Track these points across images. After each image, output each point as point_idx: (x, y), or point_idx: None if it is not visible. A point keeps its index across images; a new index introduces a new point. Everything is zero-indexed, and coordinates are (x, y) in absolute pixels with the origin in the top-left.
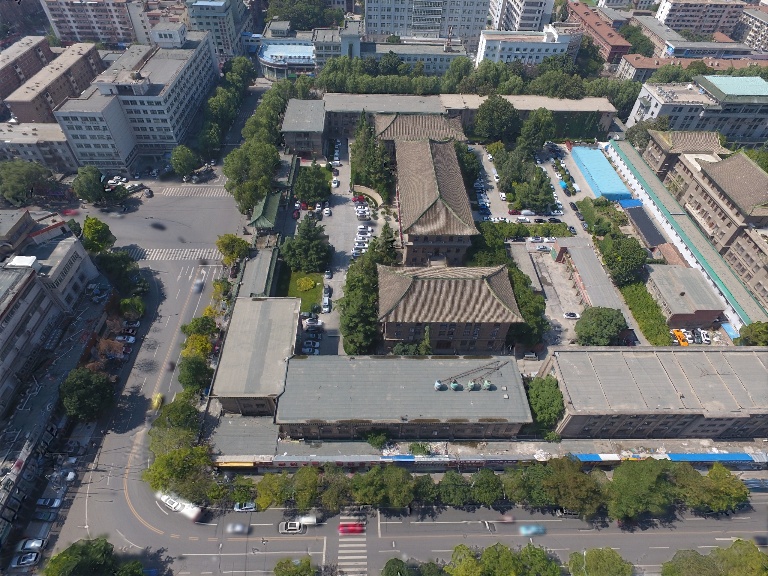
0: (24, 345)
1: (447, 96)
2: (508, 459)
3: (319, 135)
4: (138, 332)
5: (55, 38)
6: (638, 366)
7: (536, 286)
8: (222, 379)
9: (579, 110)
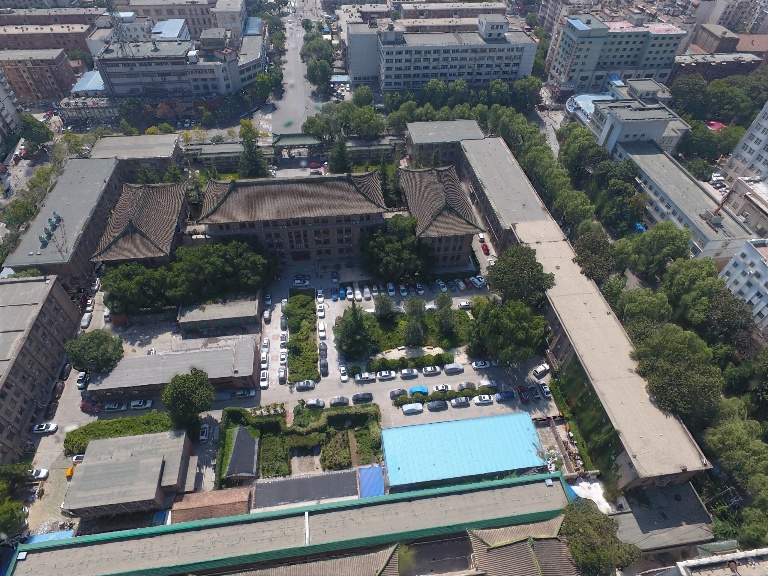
0: (159, 82)
1: (550, 225)
2: (2, 271)
3: (415, 146)
4: (194, 127)
5: (537, 17)
6: (3, 340)
7: (185, 317)
8: (111, 139)
9: (603, 397)
